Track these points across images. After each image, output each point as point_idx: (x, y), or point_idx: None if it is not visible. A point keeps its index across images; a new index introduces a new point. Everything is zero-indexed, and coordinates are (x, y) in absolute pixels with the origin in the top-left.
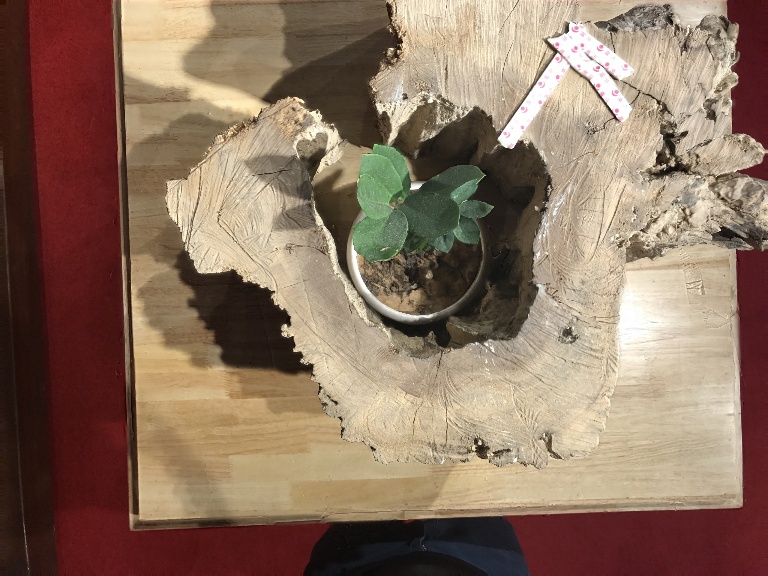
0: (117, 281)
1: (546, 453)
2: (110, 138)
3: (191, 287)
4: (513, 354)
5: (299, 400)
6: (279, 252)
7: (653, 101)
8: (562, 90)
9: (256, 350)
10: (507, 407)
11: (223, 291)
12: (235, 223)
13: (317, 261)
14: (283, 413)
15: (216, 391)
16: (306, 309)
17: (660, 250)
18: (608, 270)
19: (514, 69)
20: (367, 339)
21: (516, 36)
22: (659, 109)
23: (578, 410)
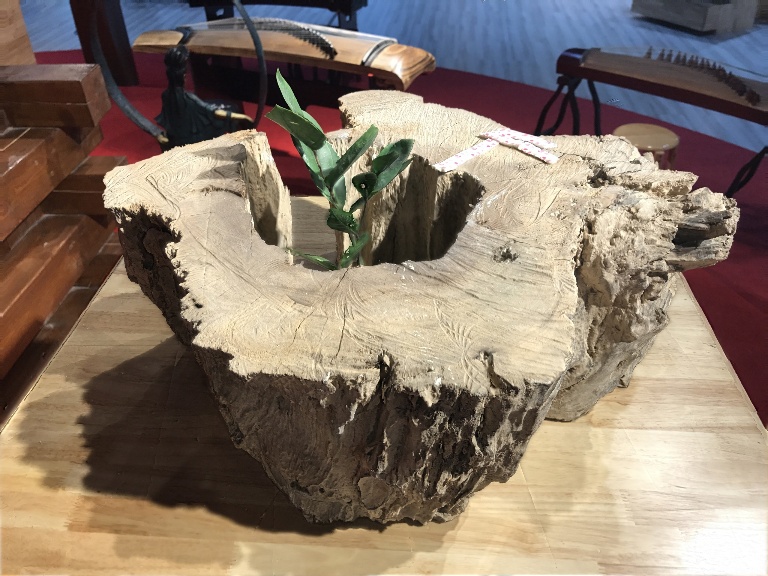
0: (10, 410)
1: (486, 377)
2: (83, 302)
3: (90, 406)
4: (437, 271)
5: (163, 542)
6: (195, 194)
7: (578, 157)
8: (493, 153)
9: (133, 475)
10: (428, 322)
11: (124, 412)
12: (162, 176)
13: (231, 201)
14: (132, 558)
15: (53, 519)
16: (203, 230)
17: (633, 308)
18: (551, 230)
19: (450, 144)
20: (262, 253)
21: (453, 134)
22: (585, 161)
23: (528, 327)
